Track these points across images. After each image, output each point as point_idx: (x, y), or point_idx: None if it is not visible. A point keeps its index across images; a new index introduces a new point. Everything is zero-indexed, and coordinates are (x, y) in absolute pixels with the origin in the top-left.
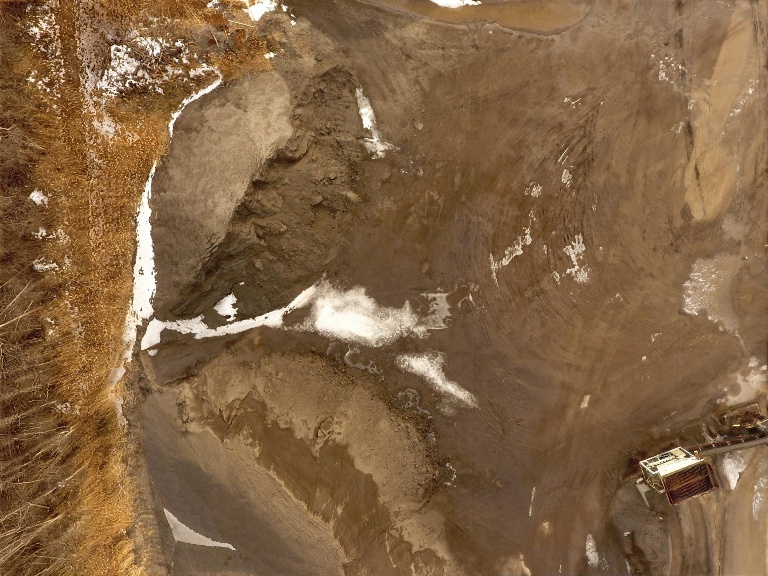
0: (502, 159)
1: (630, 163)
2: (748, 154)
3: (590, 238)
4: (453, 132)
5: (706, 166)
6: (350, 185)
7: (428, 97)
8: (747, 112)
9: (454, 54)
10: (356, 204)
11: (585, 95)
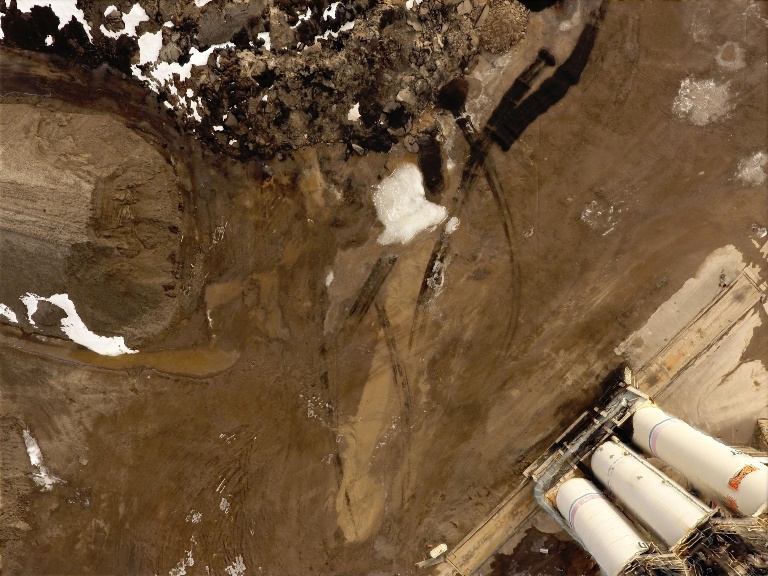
0: (163, 490)
1: (284, 492)
2: (395, 482)
3: (249, 559)
4: (116, 466)
5: (356, 493)
6: (21, 515)
7: (91, 436)
8: (391, 445)
9: (114, 398)
10: (27, 532)
11: (239, 431)
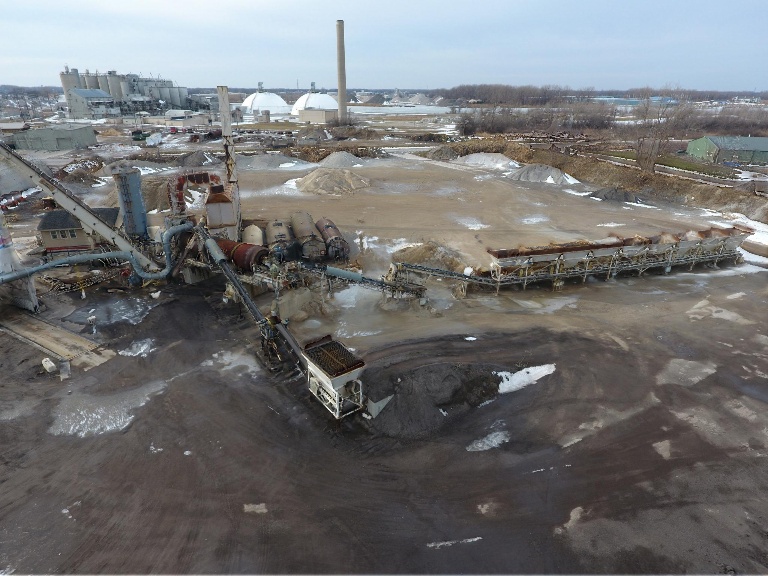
0: None
1: None
2: None
3: None
4: None
5: None
6: None
7: None
8: None
9: None
10: None
11: None
